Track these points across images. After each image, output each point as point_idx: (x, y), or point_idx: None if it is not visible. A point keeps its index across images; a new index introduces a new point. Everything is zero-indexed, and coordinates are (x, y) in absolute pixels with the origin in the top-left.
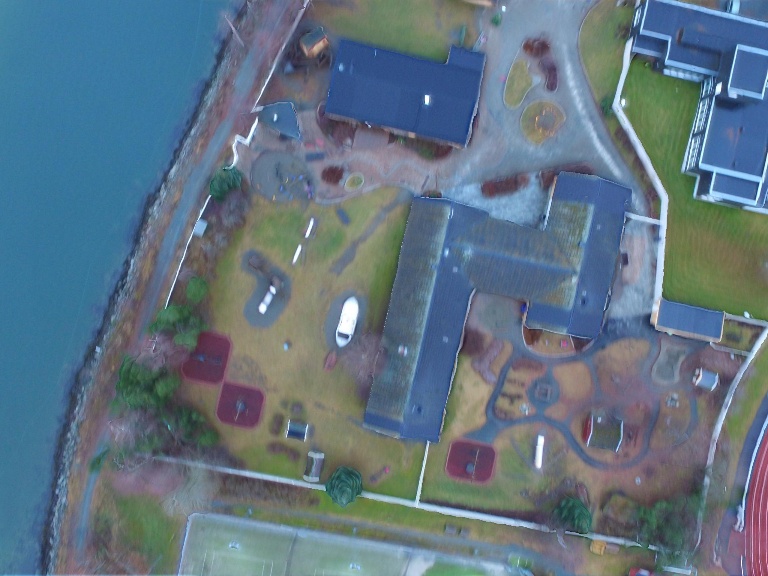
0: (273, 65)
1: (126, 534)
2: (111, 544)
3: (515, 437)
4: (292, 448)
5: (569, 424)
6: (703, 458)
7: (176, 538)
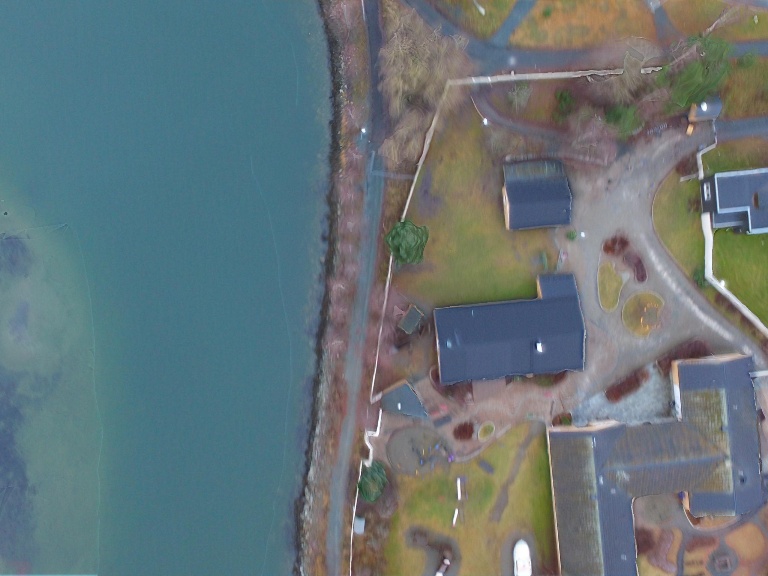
0: (377, 351)
1: None
2: None
3: None
4: None
5: None
6: None
7: None
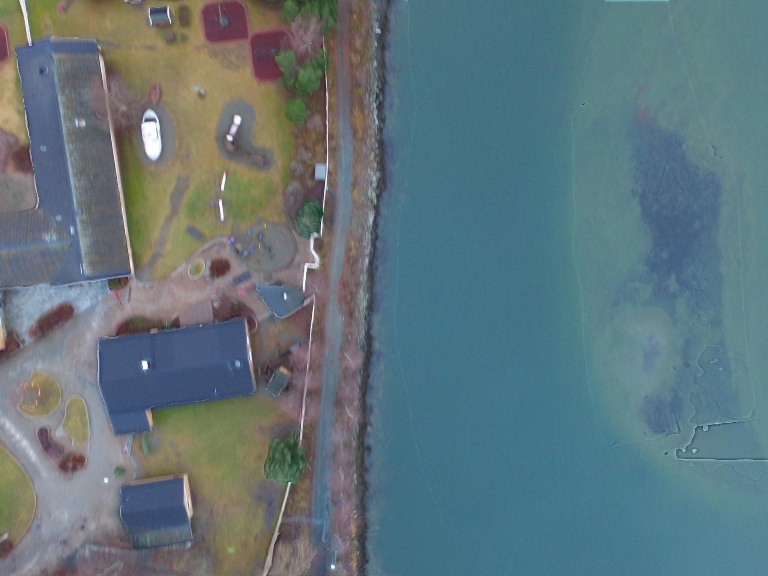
0: (312, 346)
1: None
2: None
3: None
4: None
5: None
6: None
7: None
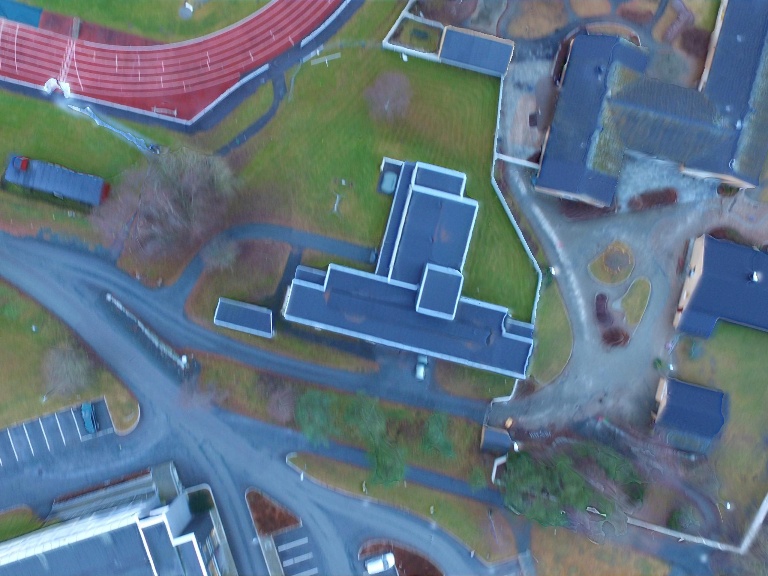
0: None
1: None
2: None
3: None
4: None
5: None
6: None
7: None
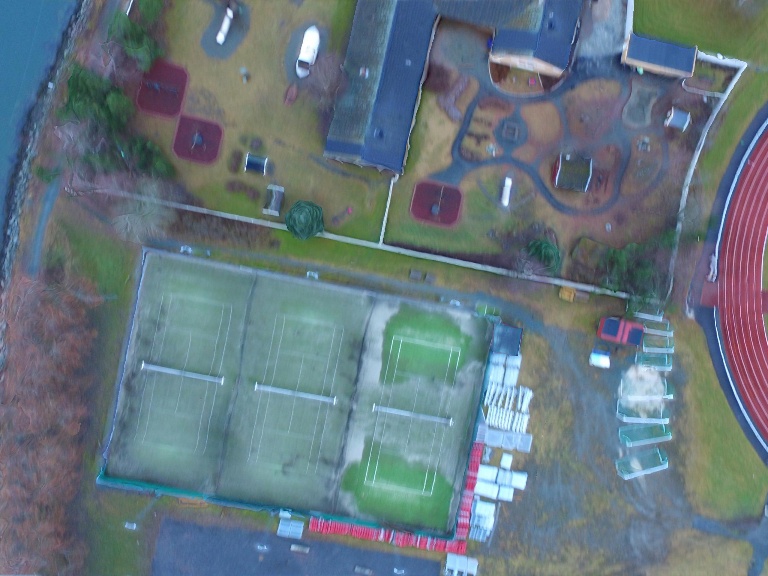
0: None
1: (79, 272)
2: (64, 281)
3: (482, 179)
4: (251, 187)
5: (537, 167)
6: (675, 205)
7: (132, 279)
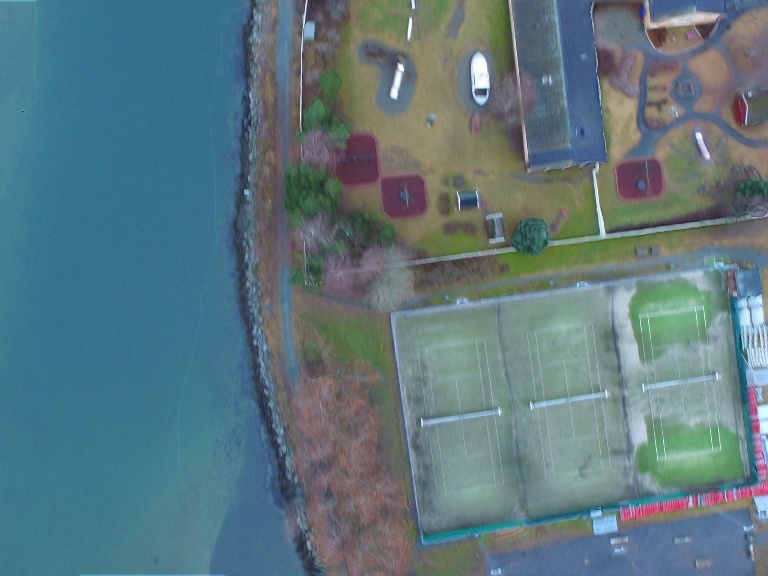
0: None
1: (337, 357)
2: (327, 370)
3: (673, 142)
4: (467, 222)
5: (720, 113)
6: None
7: (386, 346)
